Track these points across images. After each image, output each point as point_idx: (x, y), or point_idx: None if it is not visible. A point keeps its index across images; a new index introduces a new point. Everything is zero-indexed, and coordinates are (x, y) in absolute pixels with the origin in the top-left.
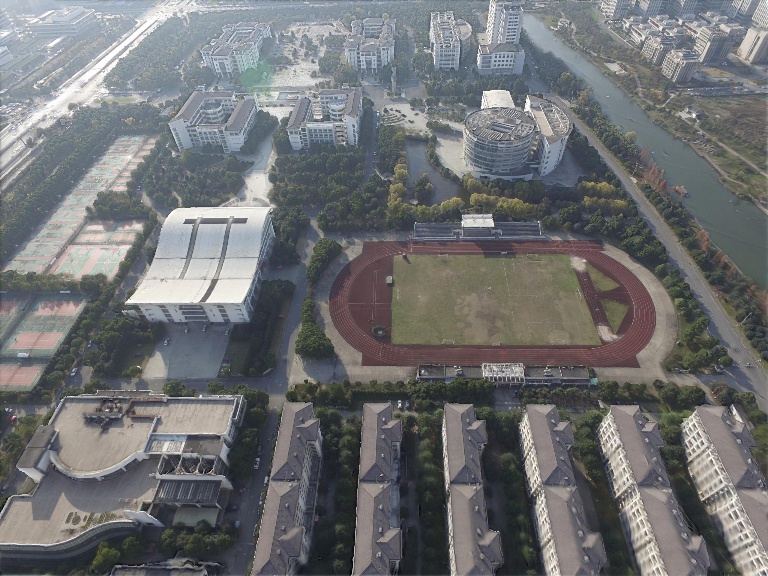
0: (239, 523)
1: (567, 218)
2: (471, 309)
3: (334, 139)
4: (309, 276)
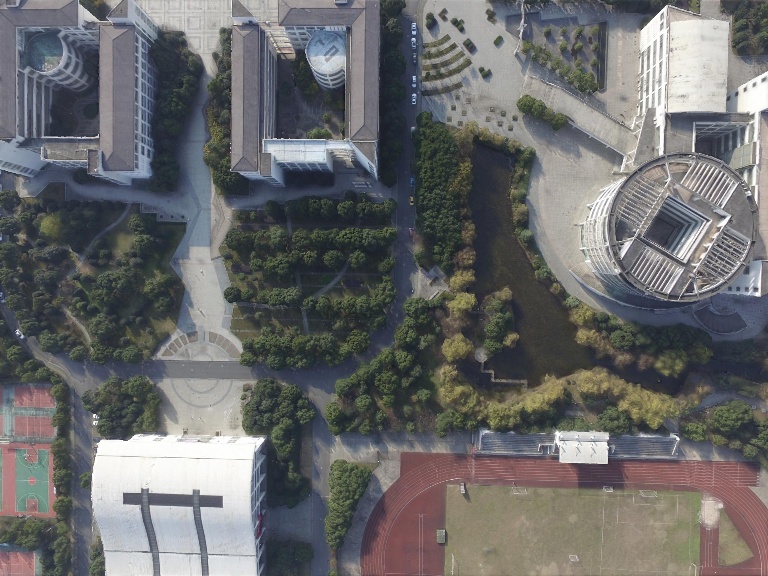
0: None
1: (725, 432)
2: None
3: (330, 164)
4: None
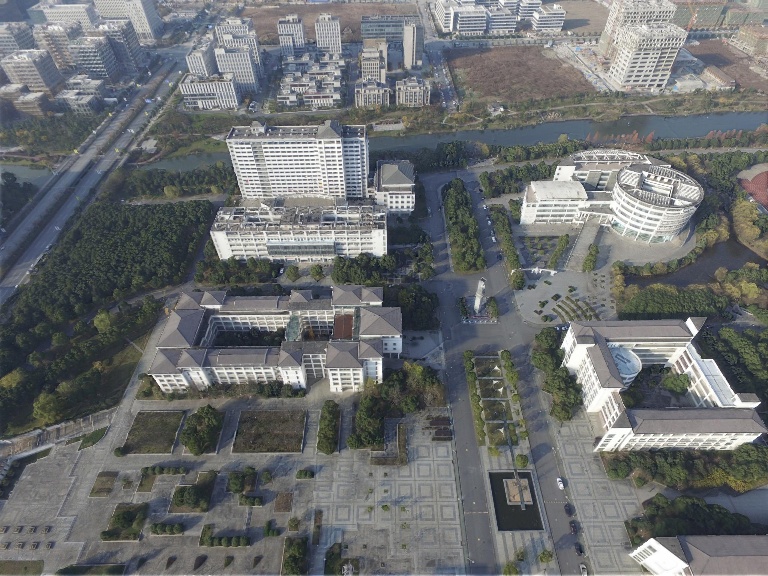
0: None
1: None
2: None
3: None
4: None
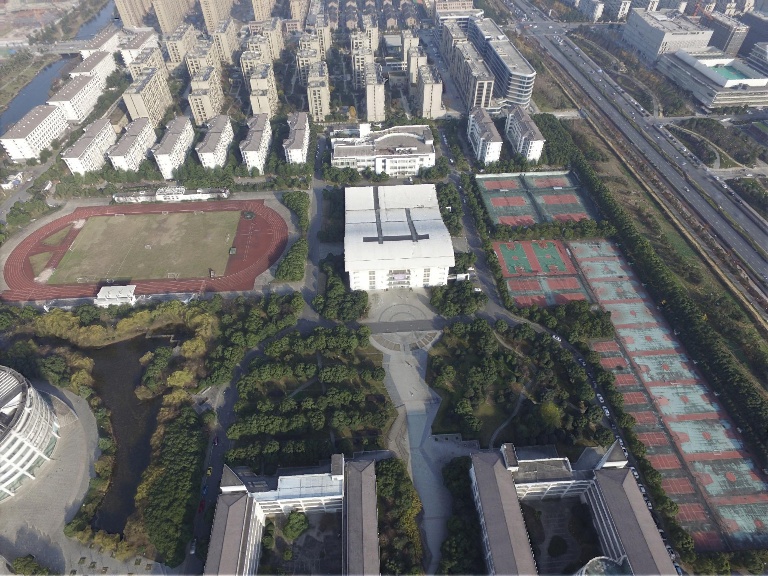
0: (326, 147)
1: (7, 312)
2: (171, 233)
3: None
4: (304, 238)
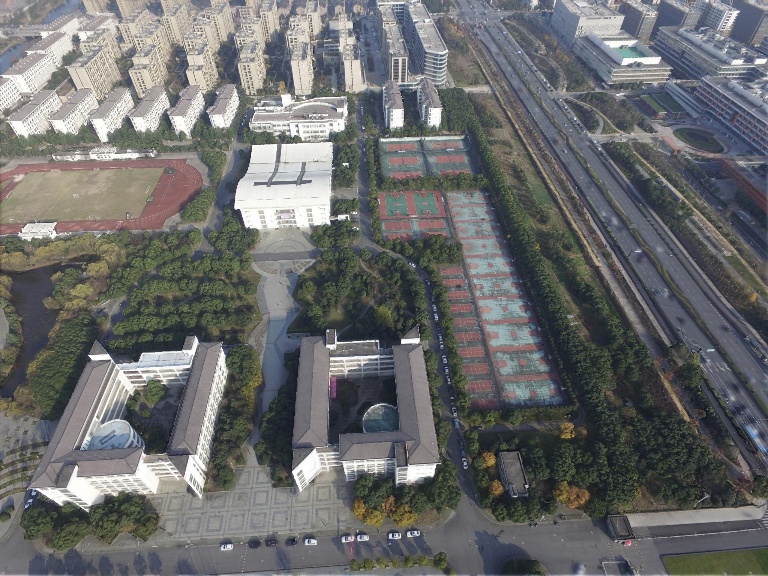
0: None
1: None
2: (99, 185)
3: None
4: (212, 187)
